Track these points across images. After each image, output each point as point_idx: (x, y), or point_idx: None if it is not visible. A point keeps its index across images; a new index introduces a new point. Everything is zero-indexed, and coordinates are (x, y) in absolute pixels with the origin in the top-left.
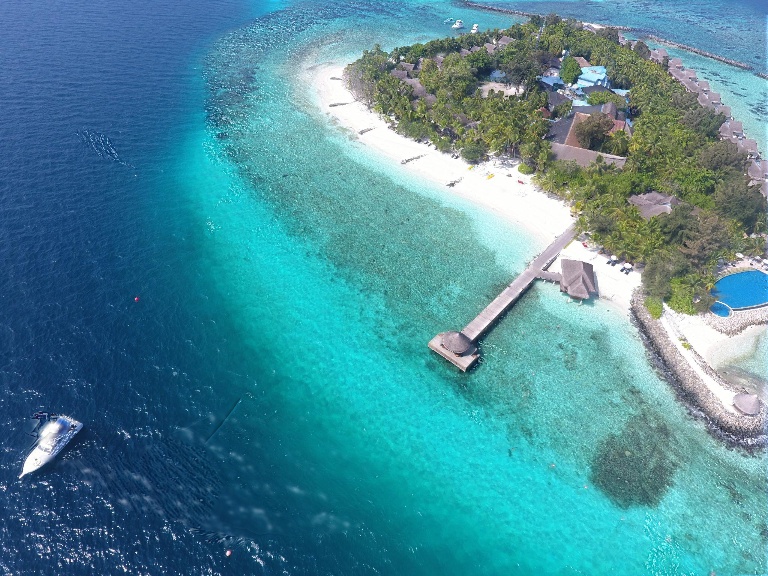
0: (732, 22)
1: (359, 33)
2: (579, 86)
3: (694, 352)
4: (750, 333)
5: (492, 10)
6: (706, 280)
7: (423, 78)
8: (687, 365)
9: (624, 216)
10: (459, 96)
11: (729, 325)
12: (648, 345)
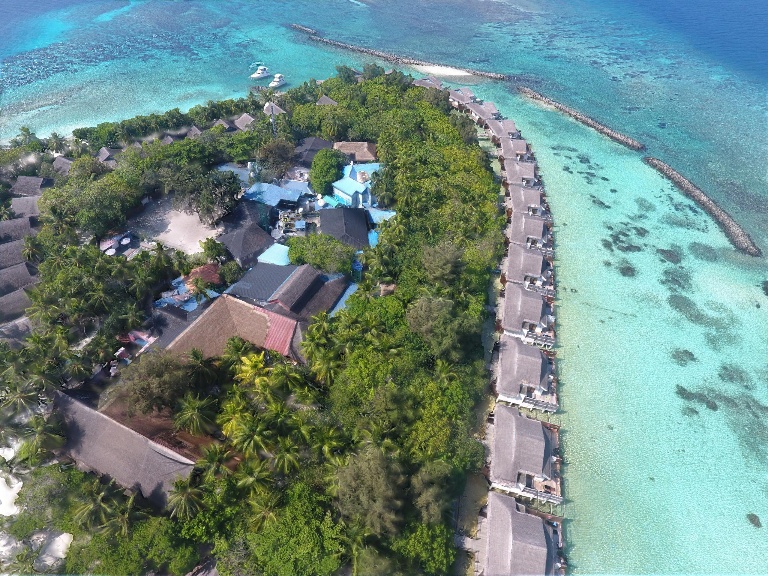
0: (651, 64)
1: (106, 87)
2: (329, 201)
3: None
4: None
5: (337, 47)
6: None
7: (43, 198)
8: None
9: None
10: (29, 255)
11: None
12: None
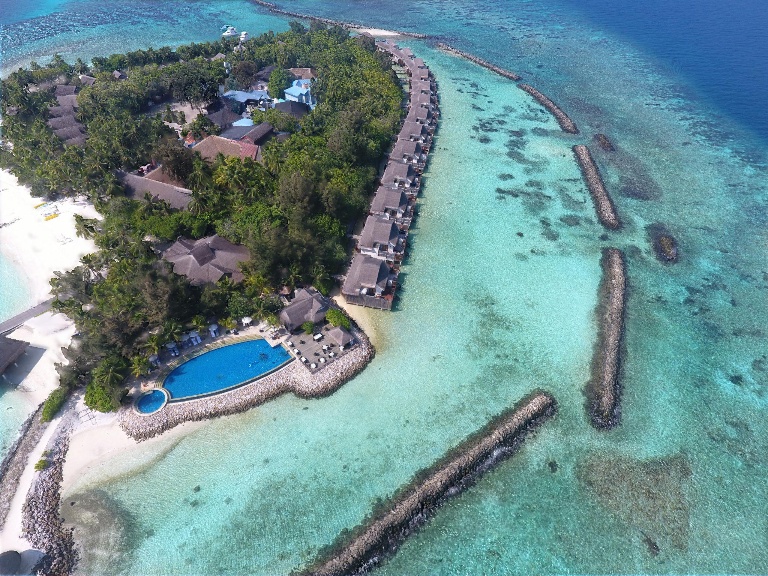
0: (547, 29)
1: (106, 41)
2: (282, 101)
3: (51, 473)
4: (173, 434)
5: (292, 16)
6: (135, 364)
7: (80, 95)
8: (6, 498)
9: (112, 274)
10: (81, 117)
11: (143, 425)
12: (5, 463)
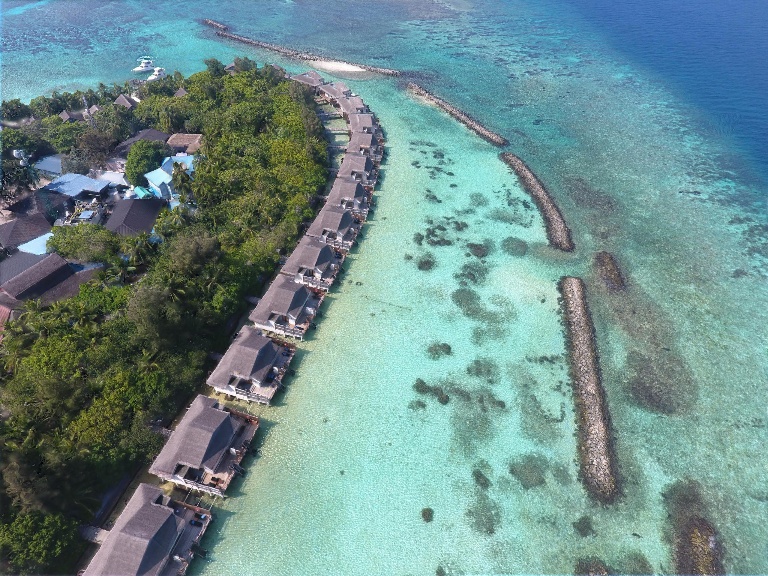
0: (558, 62)
1: None
2: (138, 192)
3: None
4: None
5: (240, 42)
6: None
7: None
8: None
9: None
10: None
11: None
12: None
